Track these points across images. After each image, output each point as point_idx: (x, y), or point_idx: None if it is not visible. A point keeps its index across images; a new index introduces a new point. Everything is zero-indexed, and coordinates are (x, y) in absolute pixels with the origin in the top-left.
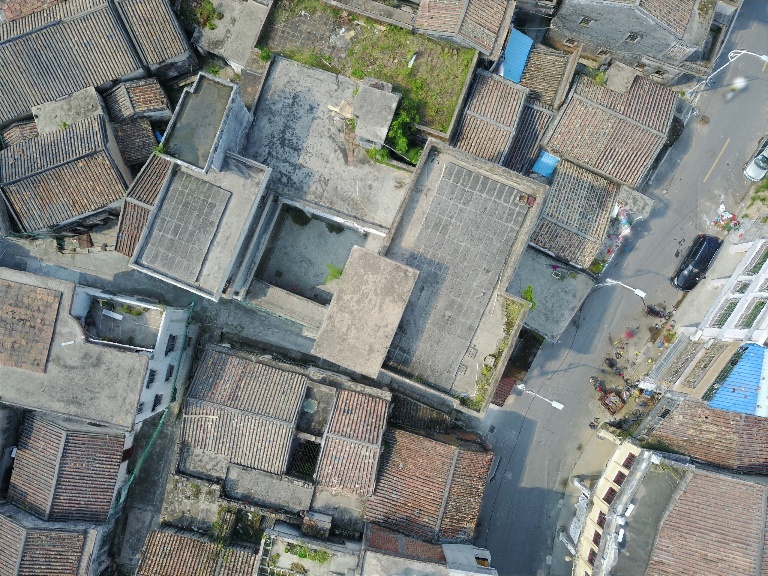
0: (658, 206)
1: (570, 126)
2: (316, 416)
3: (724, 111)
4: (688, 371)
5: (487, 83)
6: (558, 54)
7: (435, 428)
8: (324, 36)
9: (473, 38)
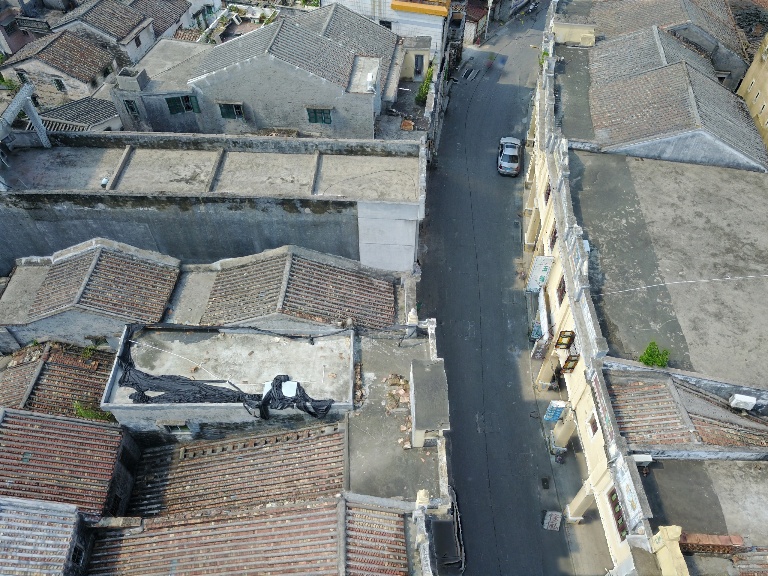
0: None
1: None
2: None
3: None
4: None
5: None
6: None
7: None
8: None
9: None
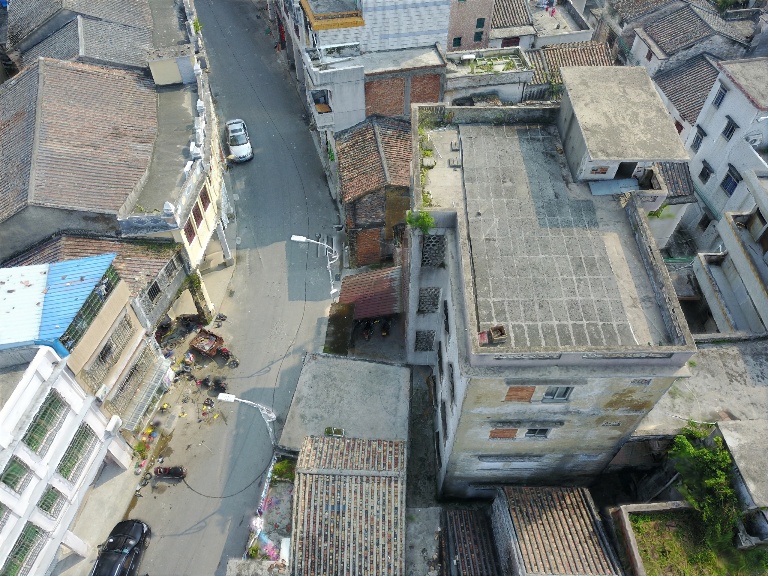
0: None
1: None
2: None
3: None
4: (127, 356)
5: None
6: None
7: None
8: None
9: None
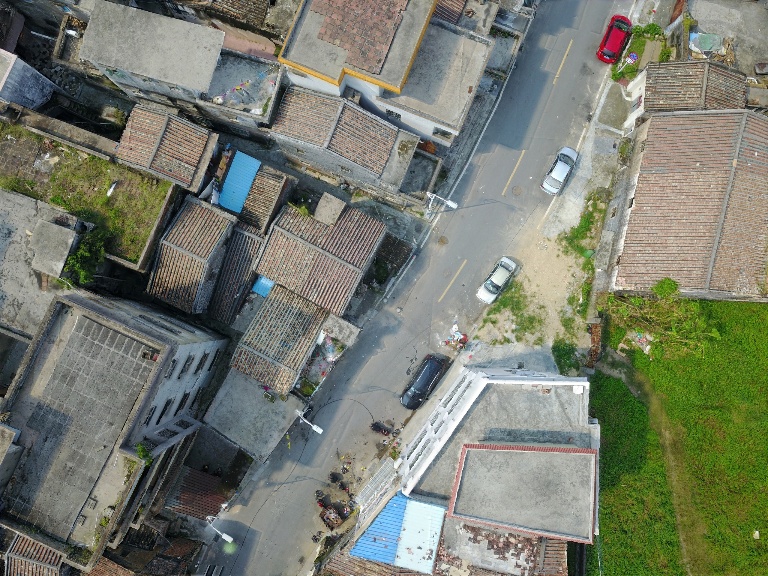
0: (393, 324)
1: (275, 255)
2: (9, 532)
3: (462, 232)
4: None
5: (193, 210)
6: (277, 180)
7: (139, 543)
8: (29, 160)
9: (168, 171)
